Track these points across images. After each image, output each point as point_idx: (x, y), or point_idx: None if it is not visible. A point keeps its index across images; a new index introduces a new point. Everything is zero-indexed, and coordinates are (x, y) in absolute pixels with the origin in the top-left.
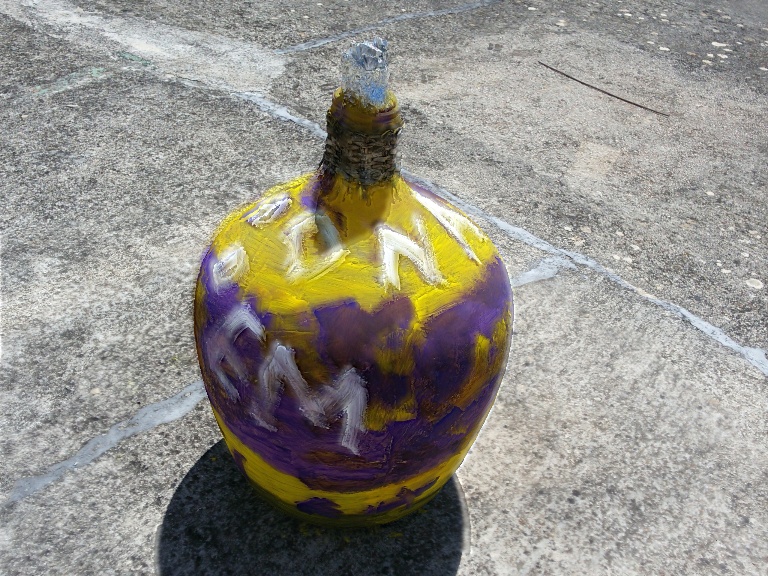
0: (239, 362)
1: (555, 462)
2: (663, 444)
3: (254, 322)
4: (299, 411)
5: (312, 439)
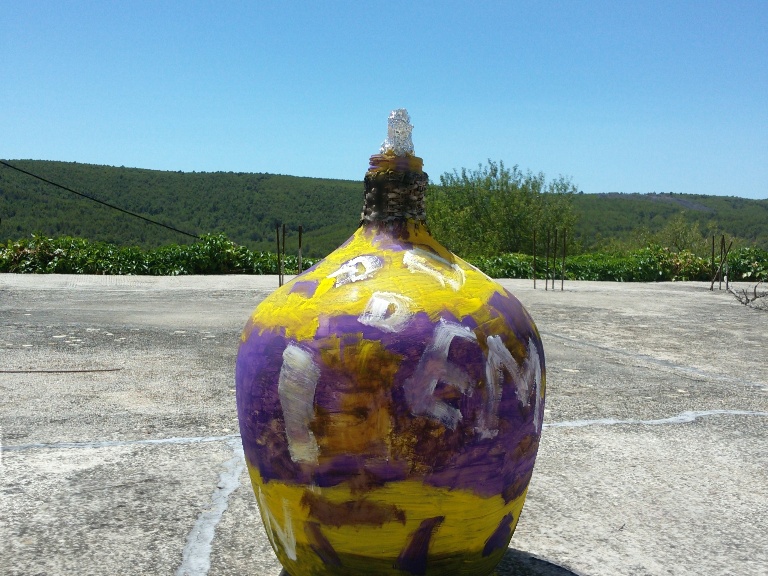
0: (459, 374)
1: None
2: None
3: (457, 329)
4: (514, 395)
5: (521, 425)
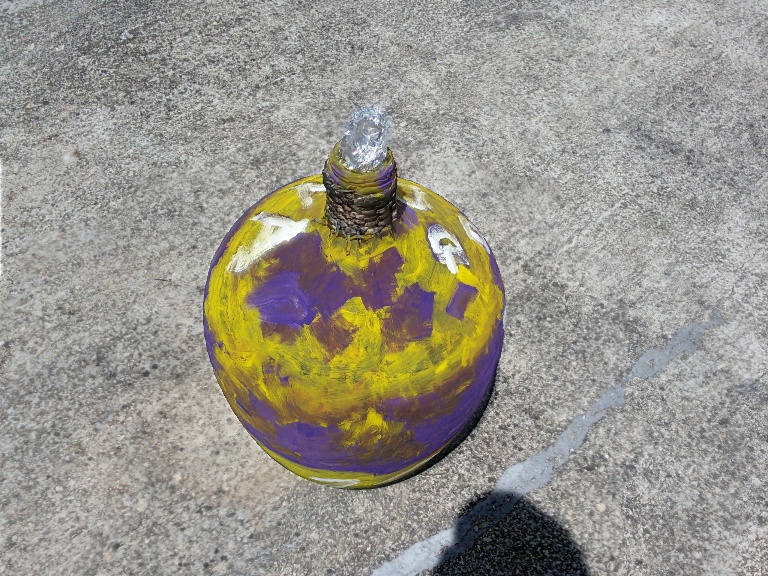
0: None
1: (150, 407)
2: (26, 425)
3: None
4: None
5: None
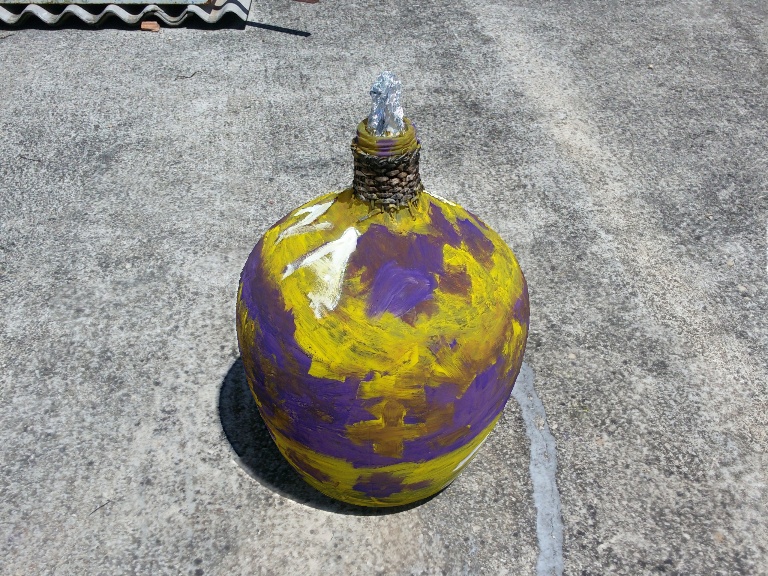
0: None
1: None
2: None
3: None
4: None
5: None
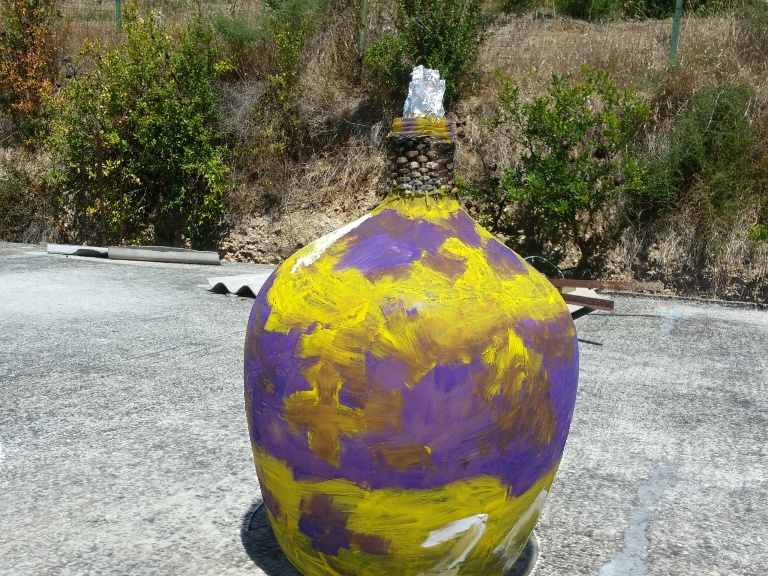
0: None
1: None
2: None
3: None
4: None
5: None
